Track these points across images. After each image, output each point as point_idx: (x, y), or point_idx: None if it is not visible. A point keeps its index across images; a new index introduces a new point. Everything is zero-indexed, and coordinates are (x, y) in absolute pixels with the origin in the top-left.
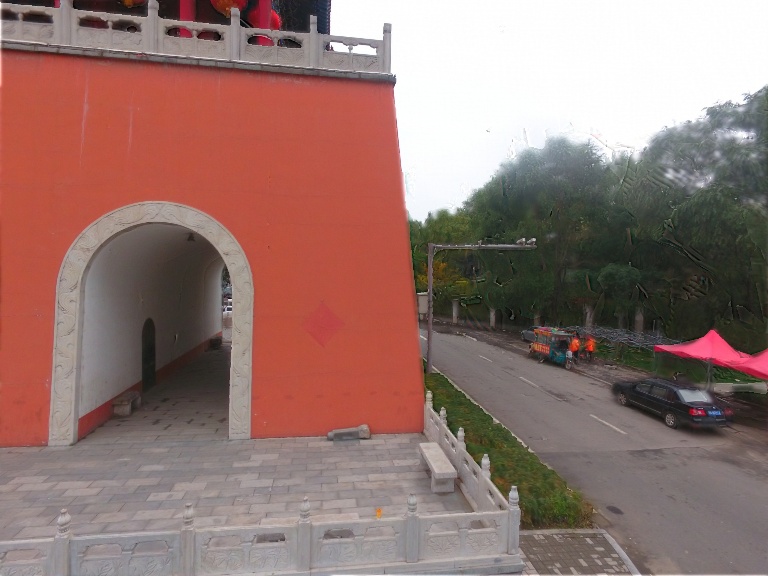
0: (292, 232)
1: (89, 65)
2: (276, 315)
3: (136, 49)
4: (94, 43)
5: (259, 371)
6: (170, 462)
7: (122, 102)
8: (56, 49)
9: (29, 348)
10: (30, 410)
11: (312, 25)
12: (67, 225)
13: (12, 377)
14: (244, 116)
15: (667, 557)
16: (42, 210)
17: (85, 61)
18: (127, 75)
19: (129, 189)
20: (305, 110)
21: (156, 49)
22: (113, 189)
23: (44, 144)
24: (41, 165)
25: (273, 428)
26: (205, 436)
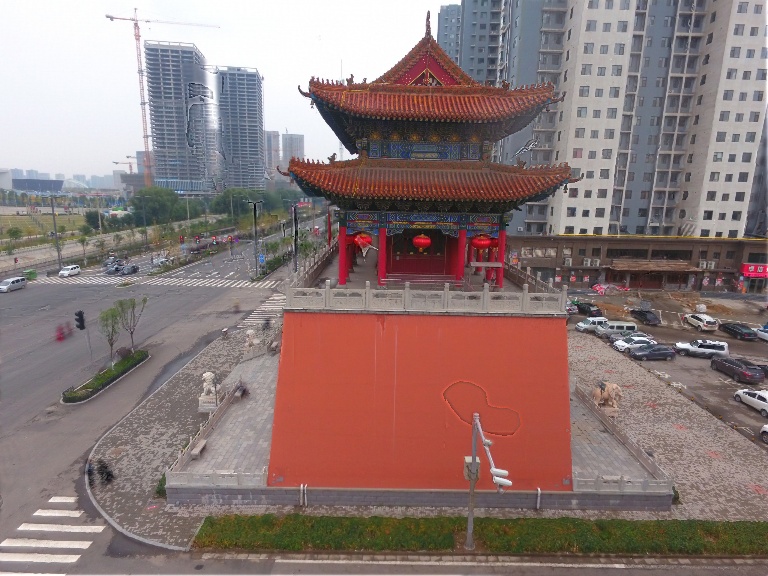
0: None
1: None
2: None
3: None
4: None
5: None
6: None
7: None
8: None
9: None
10: None
11: None
12: None
13: None
14: None
15: (163, 565)
16: None
17: None
18: None
19: None
20: None
21: None
22: None
23: None
24: None
25: None
26: None
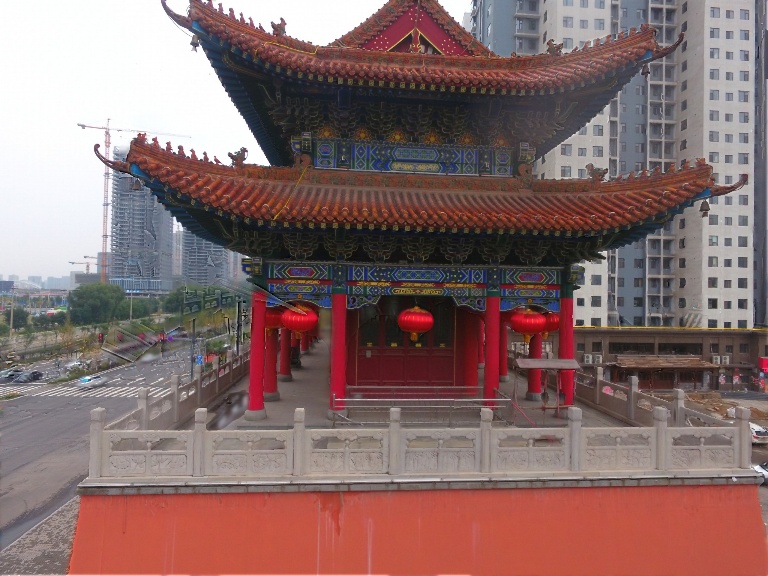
0: None
1: None
2: None
3: None
4: None
5: None
6: None
7: None
8: None
9: None
10: None
11: None
12: None
13: None
14: None
15: None
16: None
17: None
18: None
19: None
20: None
21: None
22: None
23: None
24: None
25: None
26: None
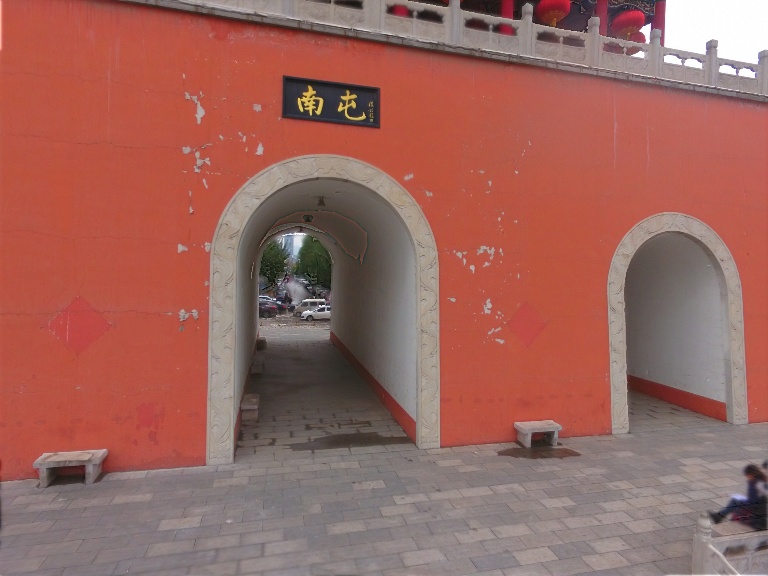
0: (762, 241)
1: (615, 87)
2: (757, 314)
3: (644, 74)
4: (614, 67)
5: (749, 364)
6: (751, 443)
7: (639, 122)
8: (596, 72)
9: (590, 345)
10: (596, 402)
11: (766, 58)
12: (609, 233)
13: (581, 372)
14: (724, 137)
15: None
16: (590, 219)
17: (612, 83)
18: (644, 97)
19: (649, 201)
20: (765, 133)
21: (659, 74)
22: (639, 201)
23: (588, 158)
24: (587, 178)
25: (761, 414)
26: (708, 422)
